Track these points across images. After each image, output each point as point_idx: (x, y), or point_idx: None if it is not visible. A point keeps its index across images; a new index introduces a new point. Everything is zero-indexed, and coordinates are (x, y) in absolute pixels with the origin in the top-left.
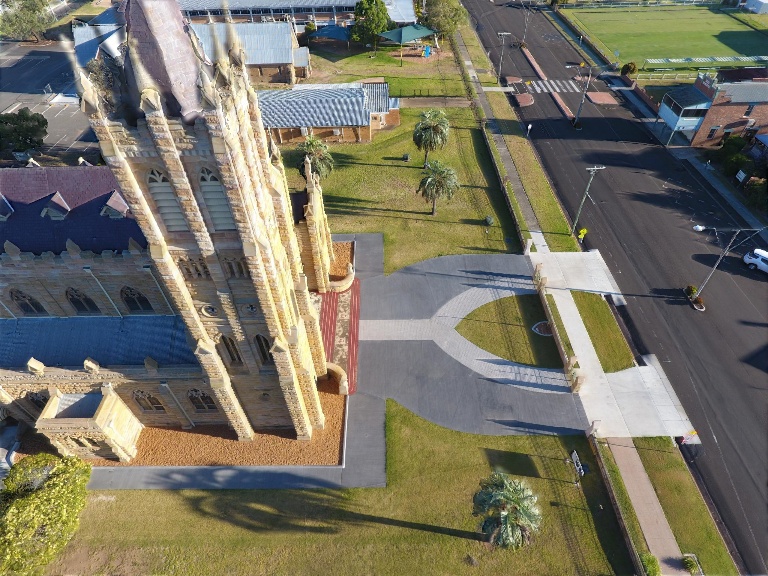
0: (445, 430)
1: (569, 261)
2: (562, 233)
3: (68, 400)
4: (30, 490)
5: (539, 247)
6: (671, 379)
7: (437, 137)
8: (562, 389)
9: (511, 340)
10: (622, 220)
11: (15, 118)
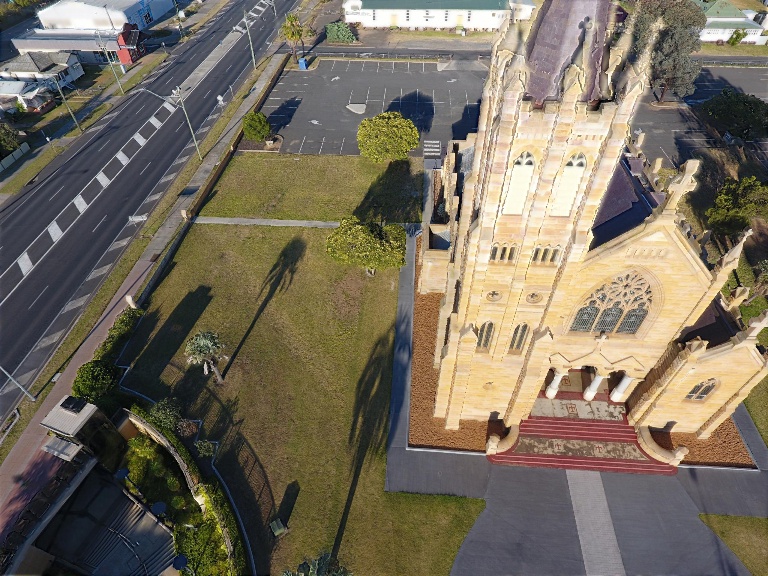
0: (447, 573)
1: None
2: None
3: (446, 235)
4: (383, 237)
5: None
6: None
7: None
8: None
9: None
10: None
11: (761, 108)
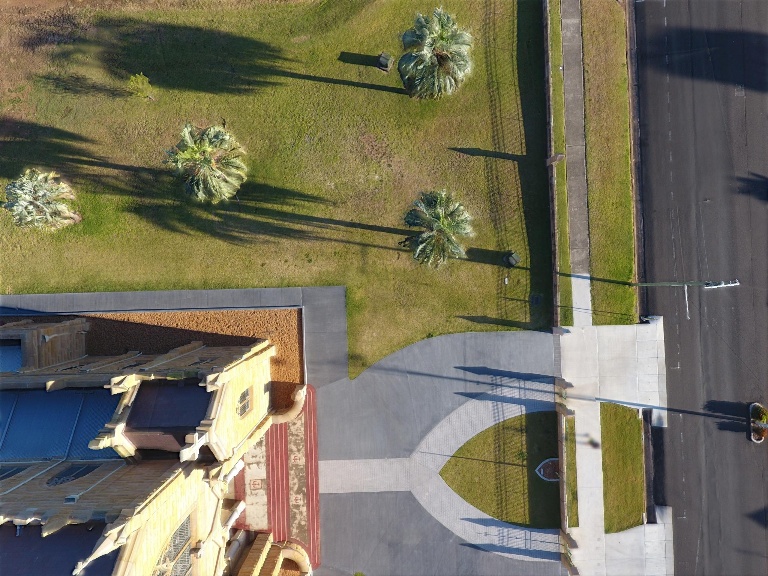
0: None
1: (614, 345)
2: (620, 281)
3: None
4: None
5: (578, 315)
6: (676, 542)
7: (445, 84)
8: (551, 556)
9: (506, 489)
10: (722, 251)
11: None
